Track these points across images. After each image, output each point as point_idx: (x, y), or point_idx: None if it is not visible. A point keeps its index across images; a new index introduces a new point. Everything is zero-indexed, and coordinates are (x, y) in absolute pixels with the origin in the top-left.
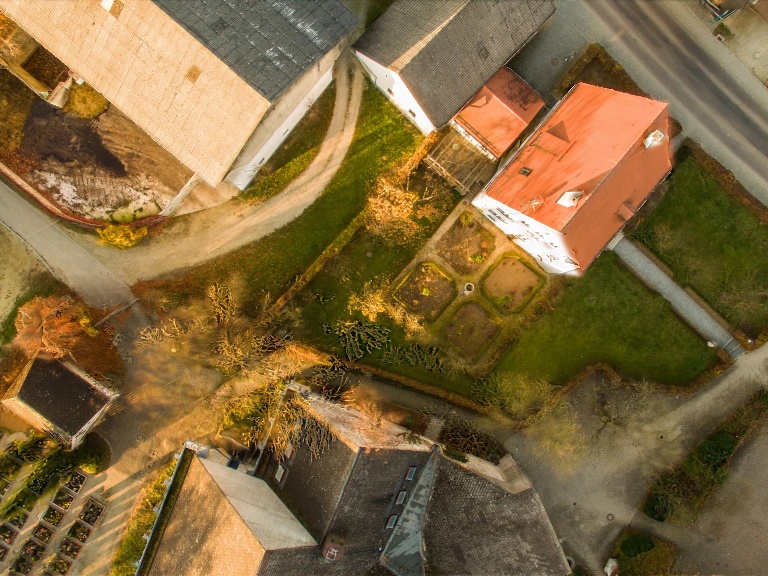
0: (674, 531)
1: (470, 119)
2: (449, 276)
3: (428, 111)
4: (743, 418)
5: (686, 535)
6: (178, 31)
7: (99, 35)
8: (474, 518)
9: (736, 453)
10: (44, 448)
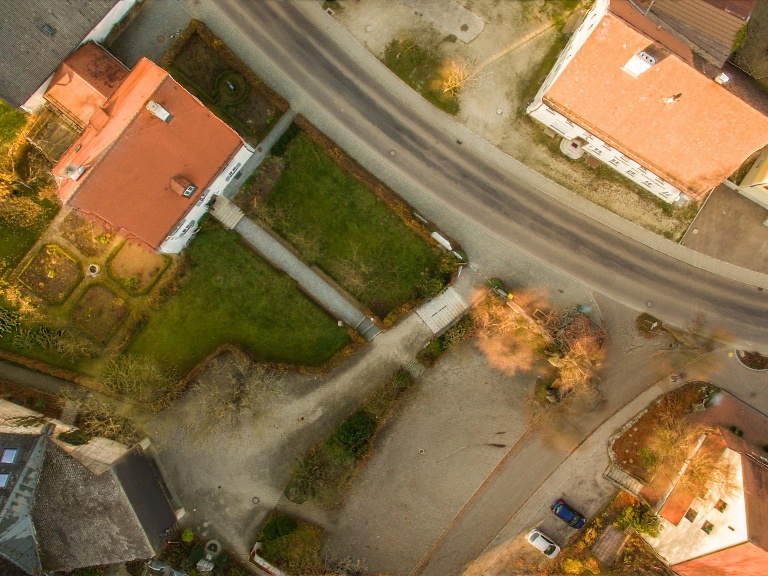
0: (321, 514)
1: (60, 98)
2: (74, 258)
3: None
4: (382, 398)
5: (333, 518)
6: None
7: None
8: (69, 500)
9: (379, 434)
10: None
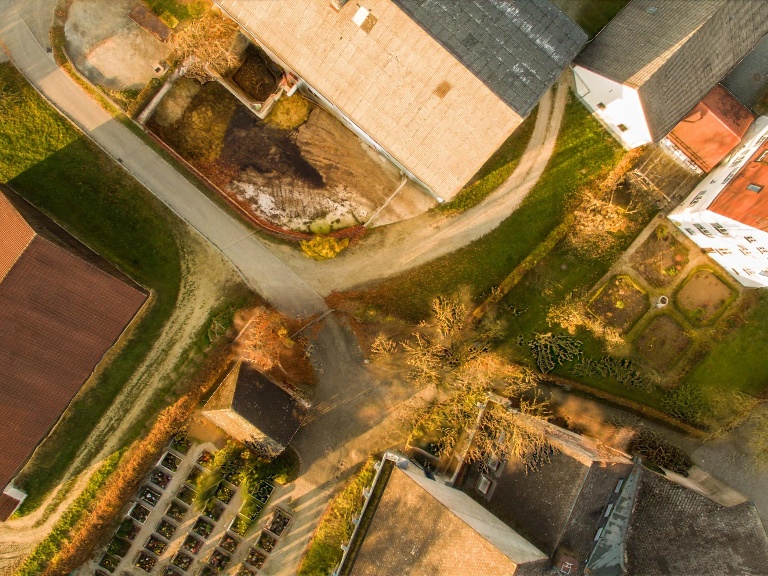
0: None
1: (681, 134)
2: (643, 289)
3: (652, 126)
4: None
5: None
6: (433, 47)
7: (345, 49)
8: (683, 531)
9: None
10: (246, 459)
